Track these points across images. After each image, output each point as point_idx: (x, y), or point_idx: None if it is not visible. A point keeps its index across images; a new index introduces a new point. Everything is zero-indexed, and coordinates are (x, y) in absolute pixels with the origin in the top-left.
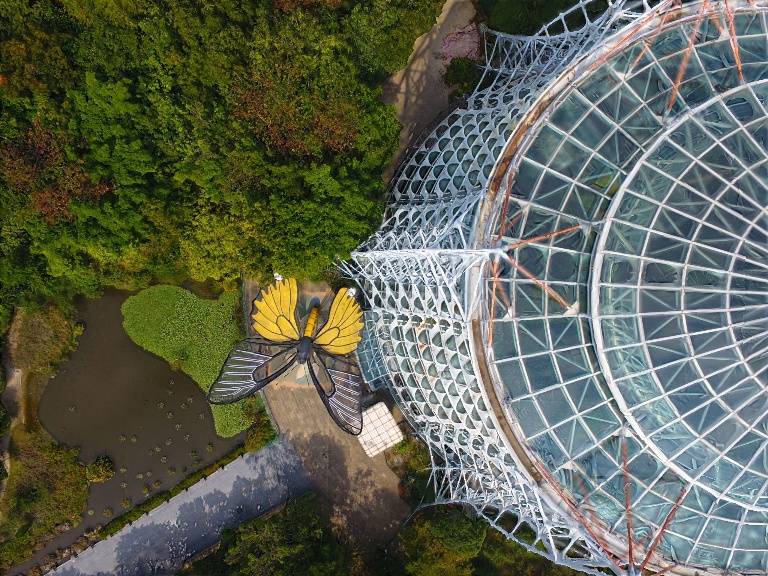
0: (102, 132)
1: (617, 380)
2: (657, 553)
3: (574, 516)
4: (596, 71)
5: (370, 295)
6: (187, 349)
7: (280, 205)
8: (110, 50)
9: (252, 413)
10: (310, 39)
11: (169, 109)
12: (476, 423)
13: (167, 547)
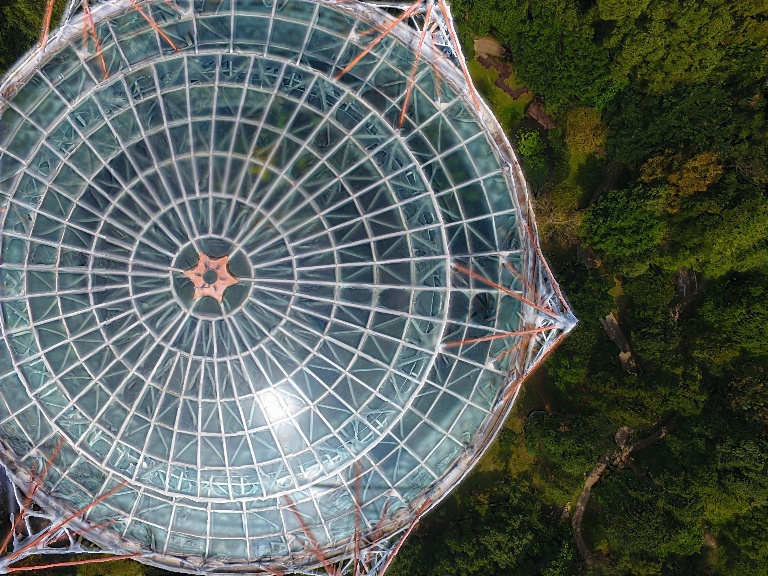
0: None
1: (18, 364)
2: (133, 542)
3: (52, 505)
4: (62, 52)
5: None
6: None
7: None
8: None
9: None
10: None
11: None
12: None
13: None
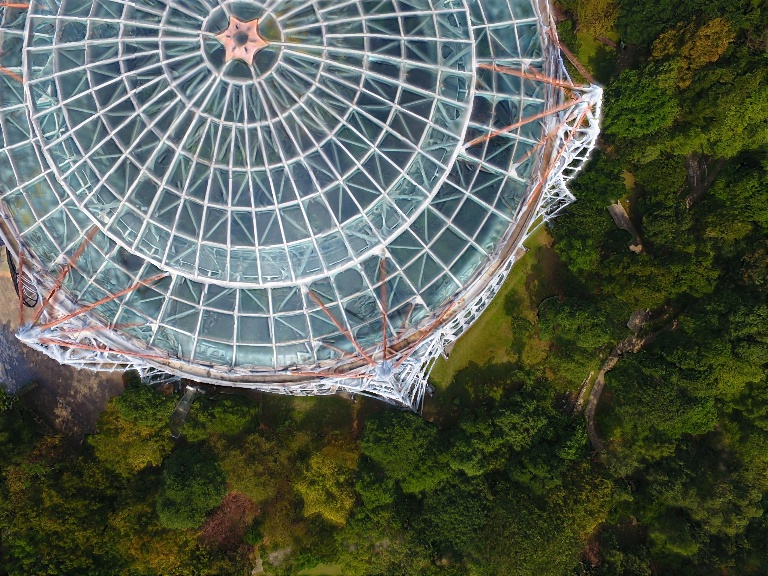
0: None
1: (47, 147)
2: (161, 350)
3: (78, 315)
4: None
5: None
6: None
7: None
8: None
9: None
10: None
11: None
12: None
13: None
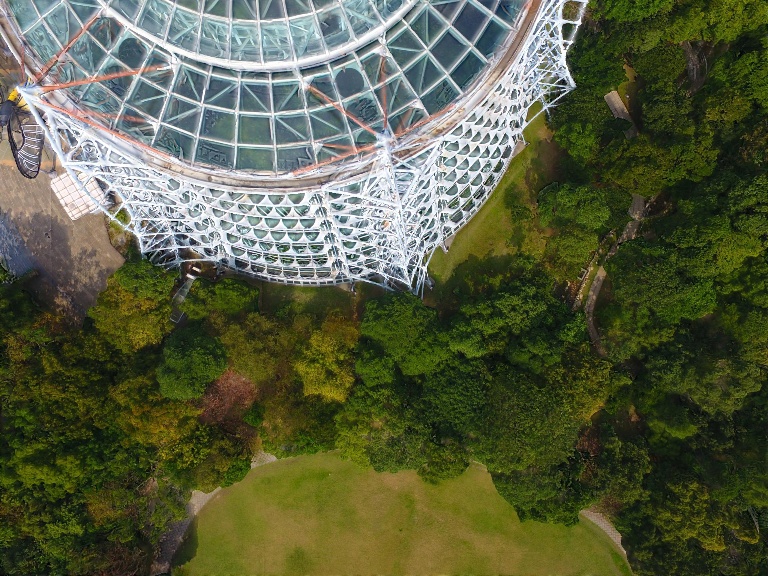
0: None
1: None
2: None
3: (80, 117)
4: None
5: None
6: None
7: None
8: None
9: None
10: None
11: None
12: None
13: None
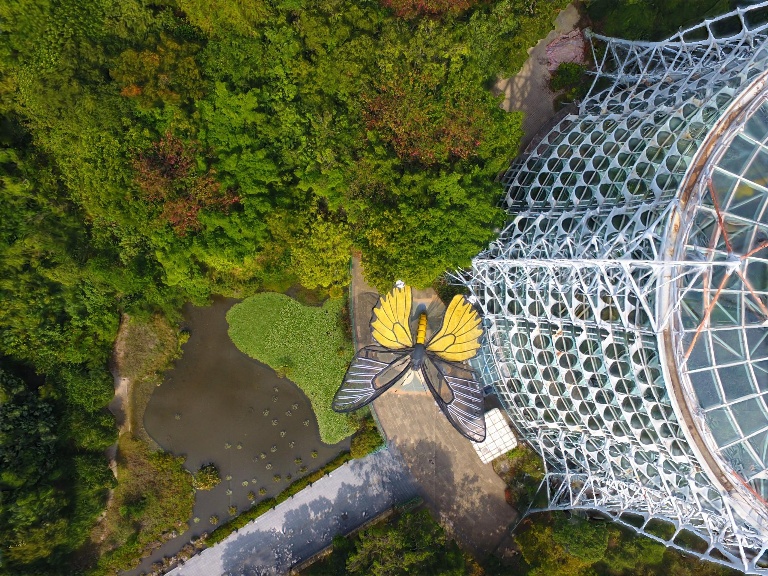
0: (228, 141)
1: None
2: None
3: (764, 525)
4: None
5: (482, 301)
6: (292, 356)
7: (410, 213)
8: (236, 60)
9: (356, 420)
10: (439, 47)
11: (293, 118)
12: (636, 431)
13: (273, 554)
